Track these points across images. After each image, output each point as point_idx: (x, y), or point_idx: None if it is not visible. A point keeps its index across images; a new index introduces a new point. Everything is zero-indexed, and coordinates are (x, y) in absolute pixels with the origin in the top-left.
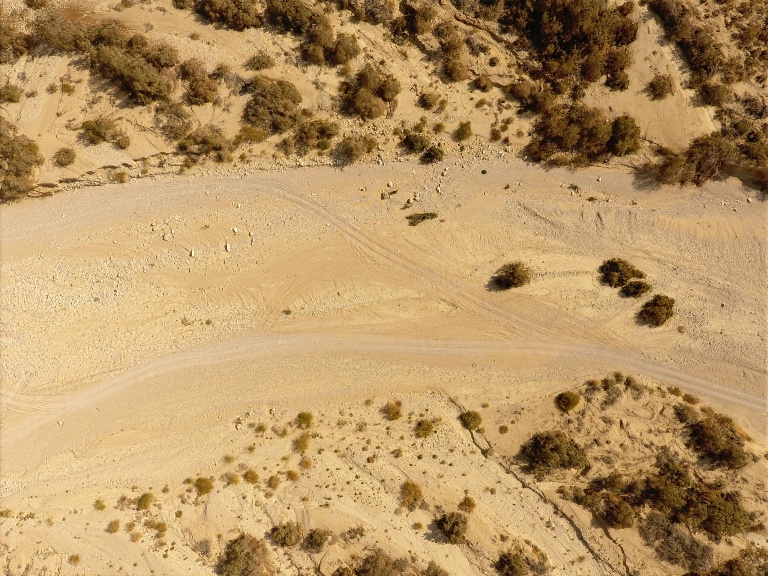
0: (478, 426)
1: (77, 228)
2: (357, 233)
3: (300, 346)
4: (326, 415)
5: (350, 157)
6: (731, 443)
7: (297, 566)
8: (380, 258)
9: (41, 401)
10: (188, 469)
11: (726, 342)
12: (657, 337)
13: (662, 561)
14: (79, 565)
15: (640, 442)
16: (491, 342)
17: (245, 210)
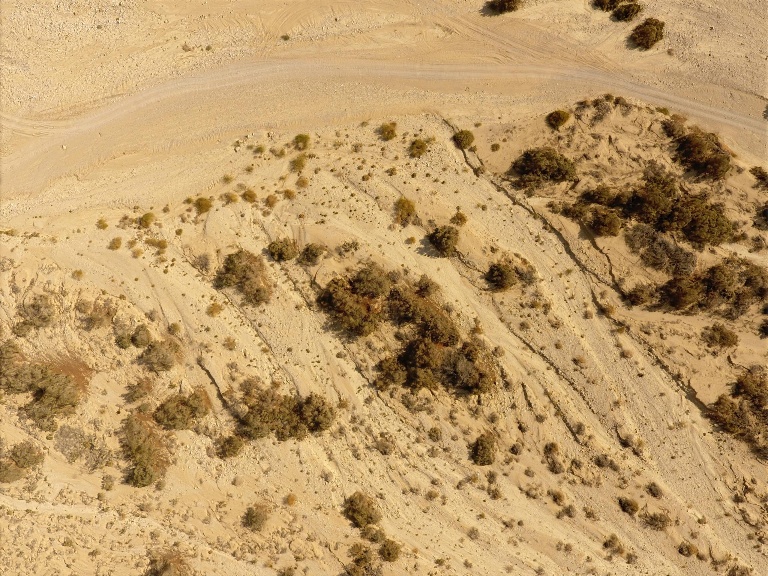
0: (471, 144)
1: None
2: None
3: (298, 71)
4: (323, 136)
5: None
6: (716, 154)
7: (293, 280)
8: None
9: (45, 126)
10: (188, 189)
11: (714, 64)
12: (647, 60)
13: (647, 268)
14: (82, 280)
15: (628, 156)
16: (484, 66)
17: None
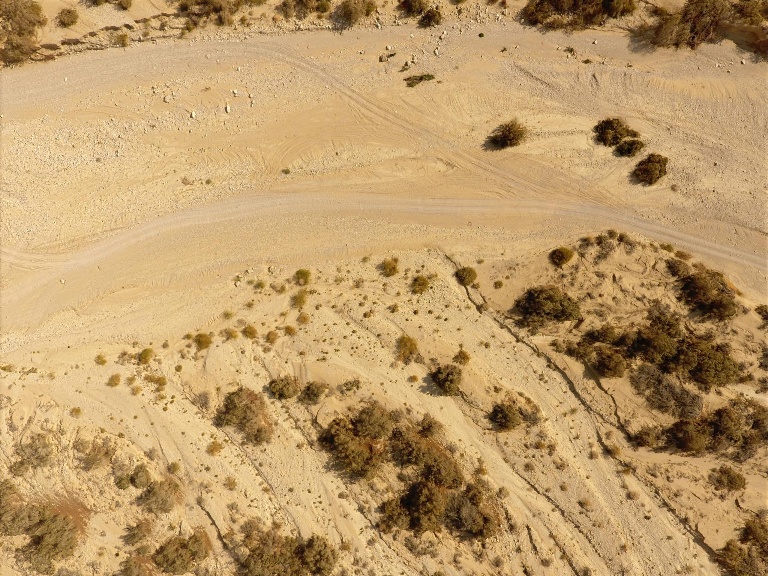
0: (473, 281)
1: (79, 91)
2: (355, 95)
3: (298, 205)
4: (324, 272)
5: (349, 20)
6: (722, 295)
7: (294, 418)
8: (378, 119)
9: (43, 259)
10: (188, 325)
11: (718, 200)
12: (650, 195)
13: (653, 410)
14: (80, 417)
15: (632, 295)
16: (487, 201)
17: (245, 73)
